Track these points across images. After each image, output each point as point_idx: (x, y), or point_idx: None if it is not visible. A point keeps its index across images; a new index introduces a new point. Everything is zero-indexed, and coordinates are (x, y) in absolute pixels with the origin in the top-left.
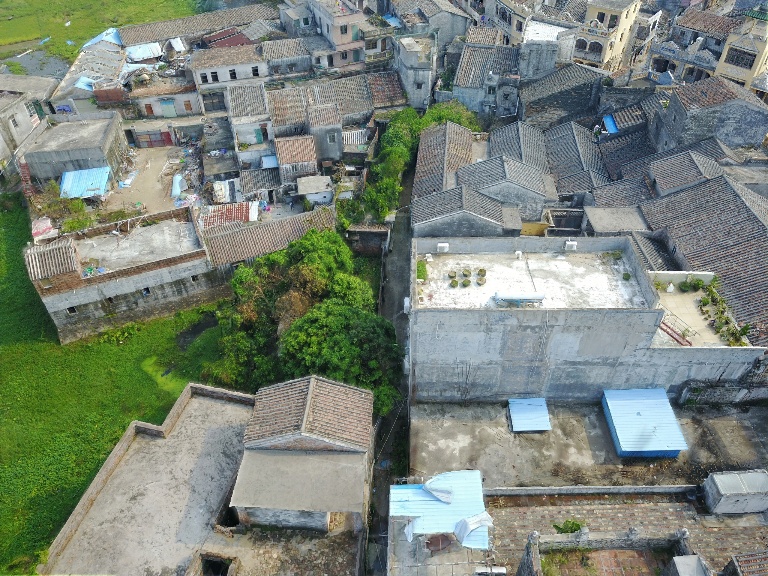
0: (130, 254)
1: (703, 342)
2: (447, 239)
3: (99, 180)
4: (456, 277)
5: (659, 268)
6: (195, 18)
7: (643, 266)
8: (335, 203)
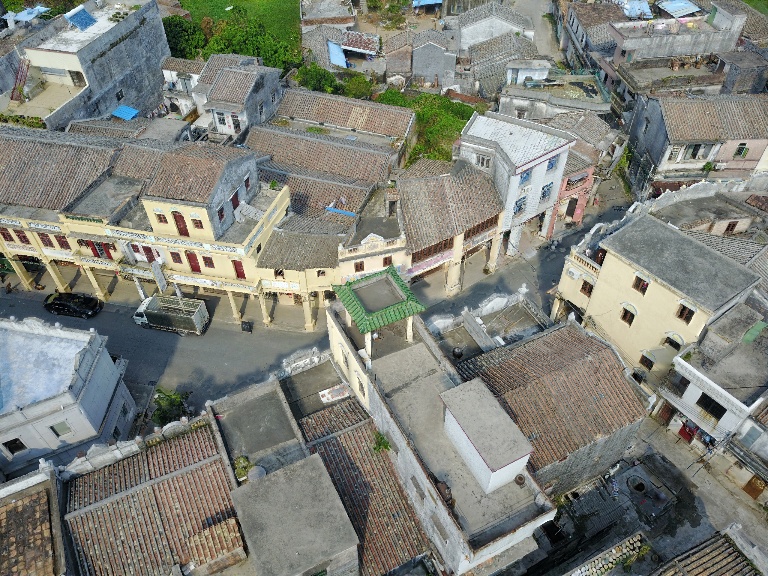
0: (322, 7)
1: (18, 110)
2: (144, 5)
3: (429, 2)
4: (124, 16)
5: (95, 131)
6: (754, 14)
7: (49, 49)
8: (345, 76)
